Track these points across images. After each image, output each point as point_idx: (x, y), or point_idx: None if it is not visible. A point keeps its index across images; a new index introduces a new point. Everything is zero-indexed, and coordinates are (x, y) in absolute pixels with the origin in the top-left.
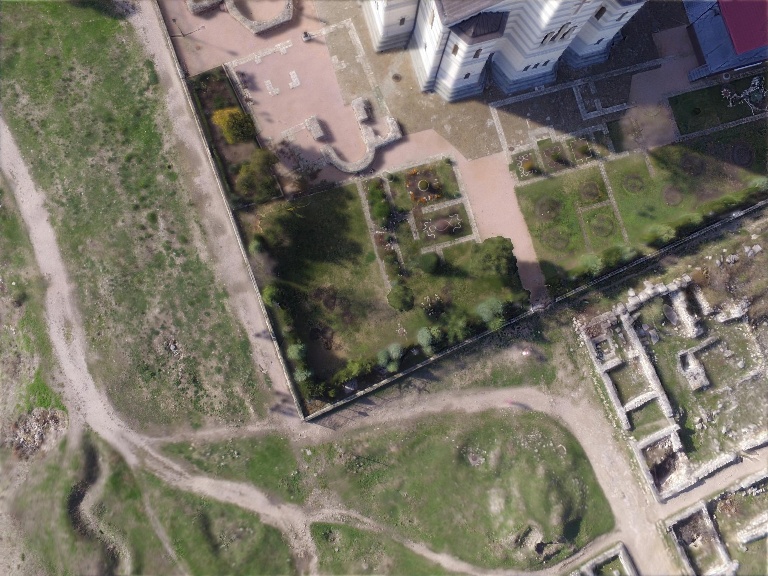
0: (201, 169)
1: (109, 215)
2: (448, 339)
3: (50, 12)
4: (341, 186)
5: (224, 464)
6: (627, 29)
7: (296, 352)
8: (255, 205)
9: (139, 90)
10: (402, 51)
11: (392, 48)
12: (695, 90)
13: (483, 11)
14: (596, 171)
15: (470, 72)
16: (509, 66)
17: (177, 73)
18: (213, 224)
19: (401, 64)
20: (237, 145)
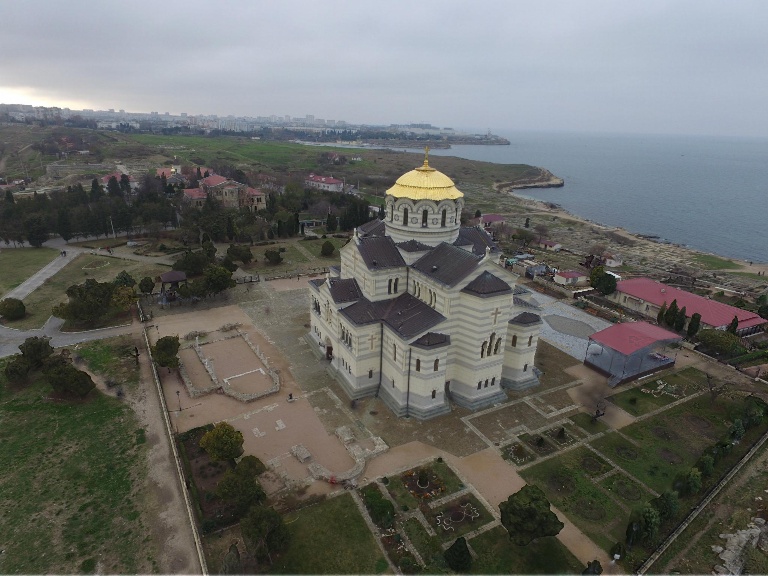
0: (171, 504)
1: (27, 572)
2: None
3: (59, 412)
4: (333, 497)
5: None
6: (542, 370)
7: None
8: (231, 529)
9: (122, 450)
10: (374, 398)
11: (365, 397)
12: (620, 392)
13: (430, 332)
14: (585, 449)
15: (435, 389)
16: (465, 387)
17: (167, 433)
18: (172, 559)
19: (375, 405)
20: (218, 476)
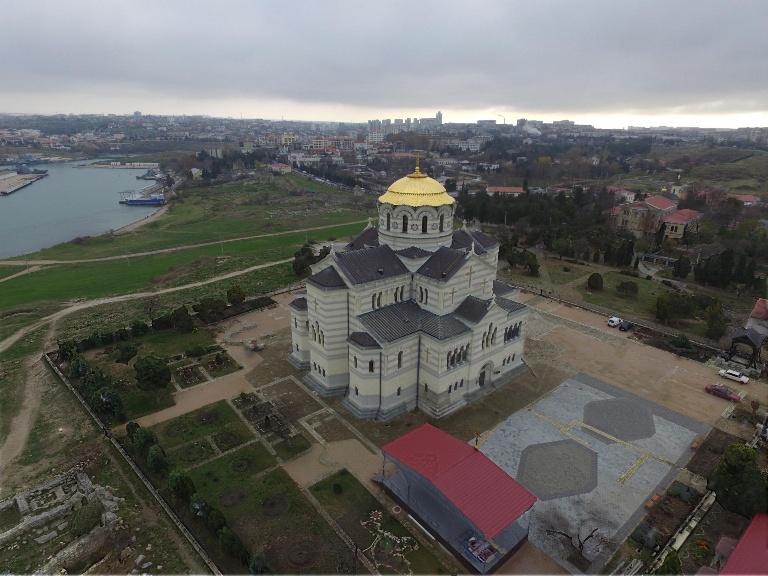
0: None
1: None
2: (88, 383)
3: None
4: None
5: (26, 340)
6: (396, 425)
7: (95, 331)
8: None
9: None
10: None
11: None
12: (365, 486)
13: None
14: (250, 438)
15: None
16: None
17: None
18: None
19: None
20: (234, 311)
